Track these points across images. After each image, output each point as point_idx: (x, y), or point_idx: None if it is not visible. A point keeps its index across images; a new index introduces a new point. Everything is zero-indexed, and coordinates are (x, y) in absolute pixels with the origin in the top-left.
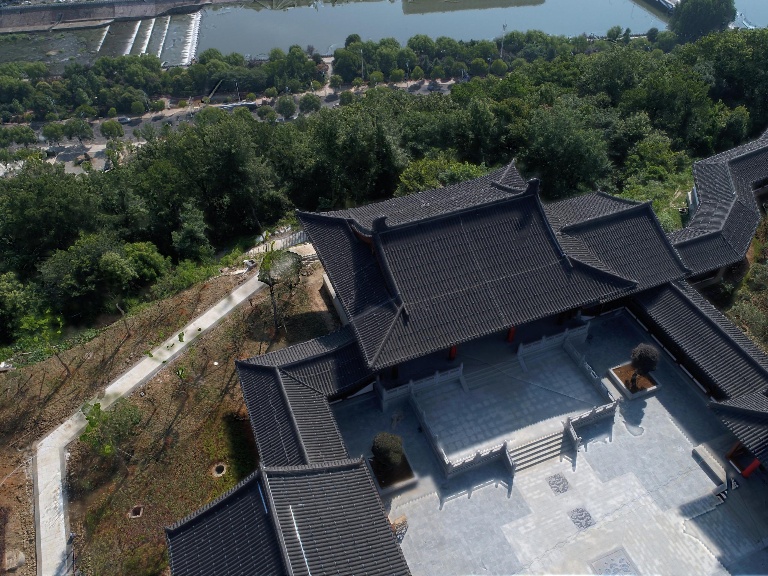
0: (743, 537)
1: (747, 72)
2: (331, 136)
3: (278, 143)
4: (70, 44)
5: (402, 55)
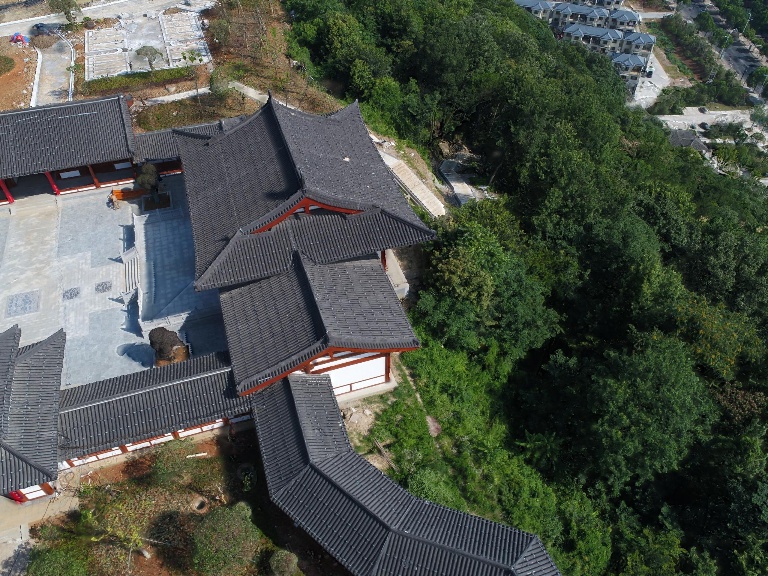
0: None
1: None
2: None
3: None
4: None
5: None
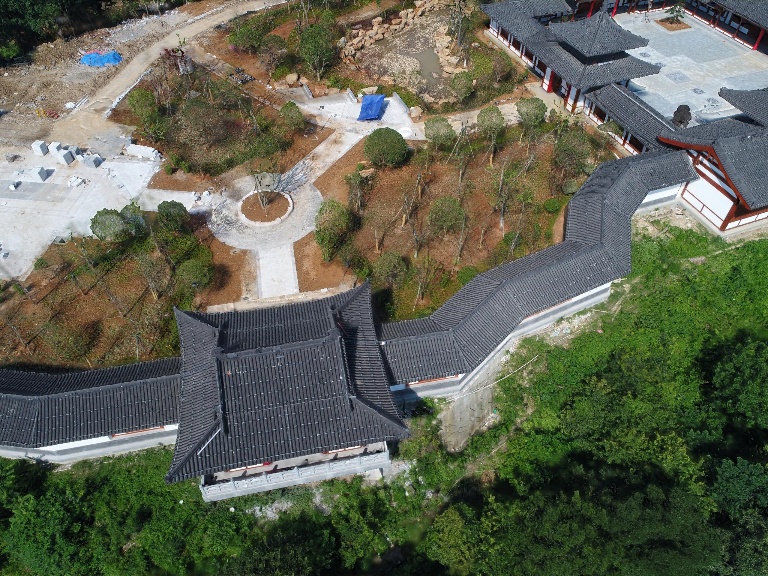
0: None
1: None
2: None
3: None
4: None
5: None
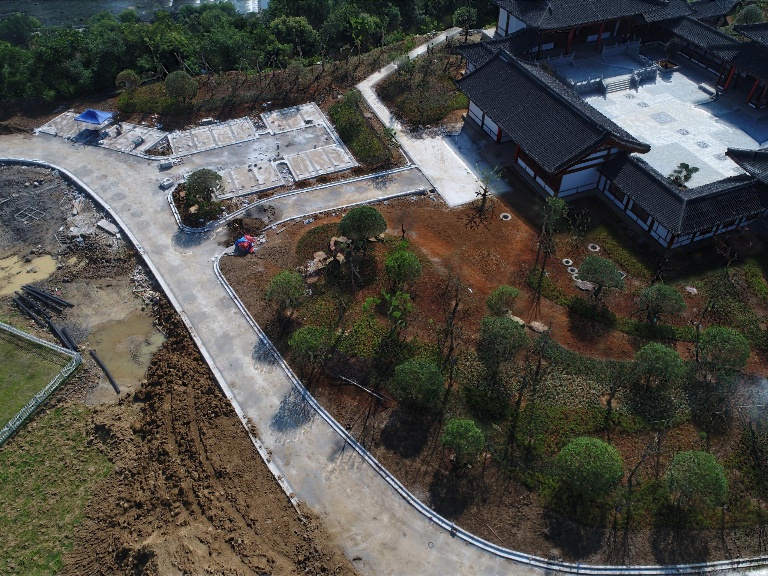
0: (724, 109)
1: None
2: None
3: None
4: (144, 1)
5: None
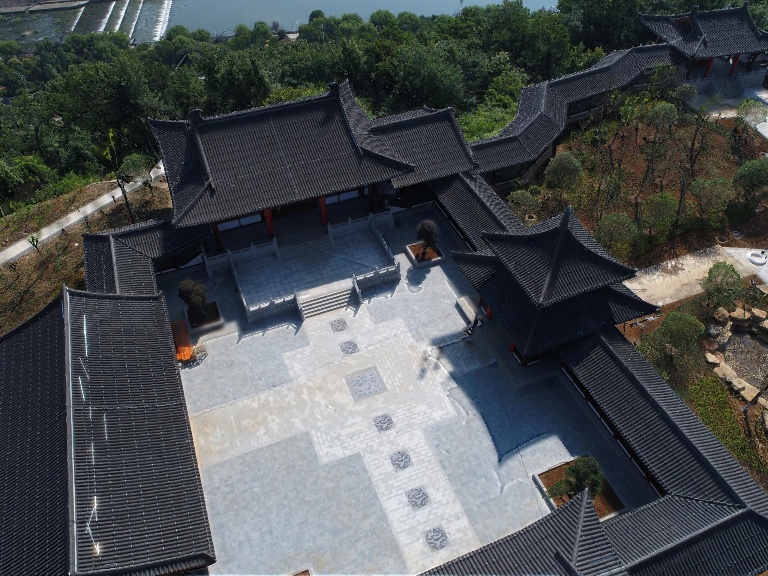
0: (475, 359)
1: (610, 18)
2: (210, 70)
3: (176, 83)
4: (45, 25)
5: (363, 30)
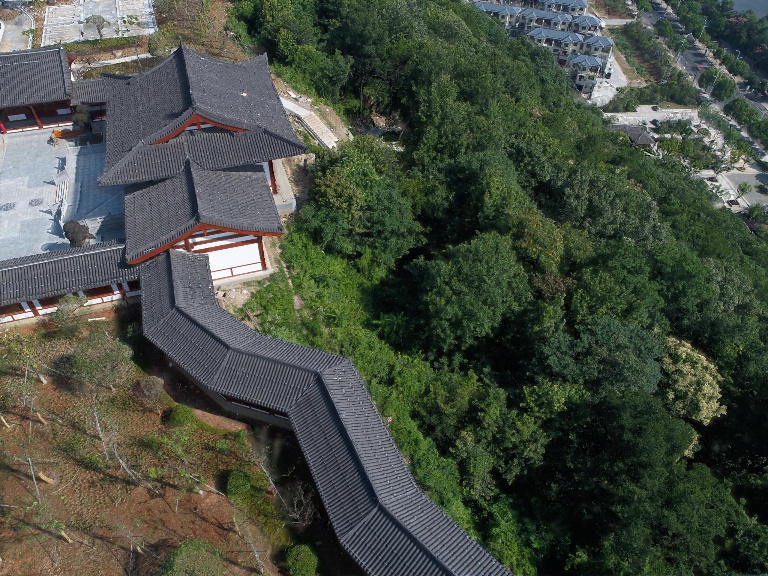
0: None
1: None
2: None
3: None
4: None
5: None
